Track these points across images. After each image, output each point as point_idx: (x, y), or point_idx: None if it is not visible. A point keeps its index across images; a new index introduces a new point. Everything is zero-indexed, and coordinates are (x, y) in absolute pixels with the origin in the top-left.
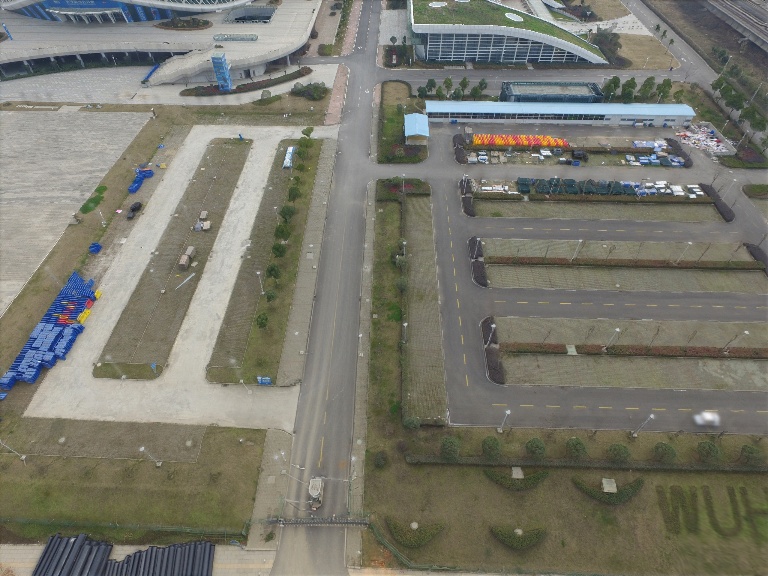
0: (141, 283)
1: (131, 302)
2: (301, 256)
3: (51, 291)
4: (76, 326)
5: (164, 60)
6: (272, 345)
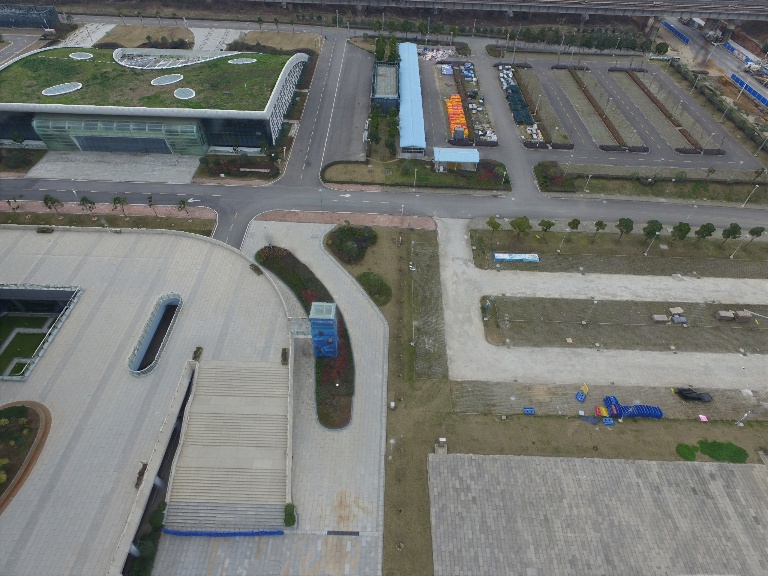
0: None
1: None
2: None
3: None
4: None
5: (162, 506)
6: None
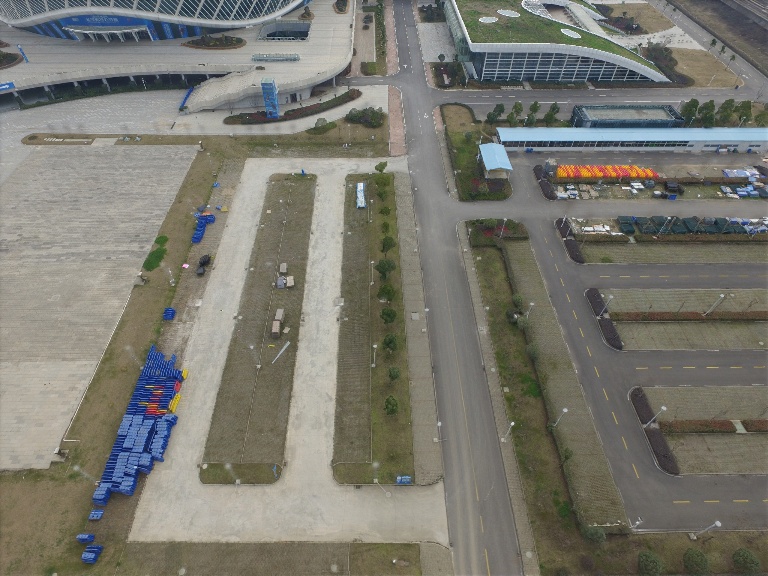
0: (231, 356)
1: (225, 382)
2: (406, 317)
3: (130, 371)
4: (170, 417)
5: (199, 83)
6: (400, 432)
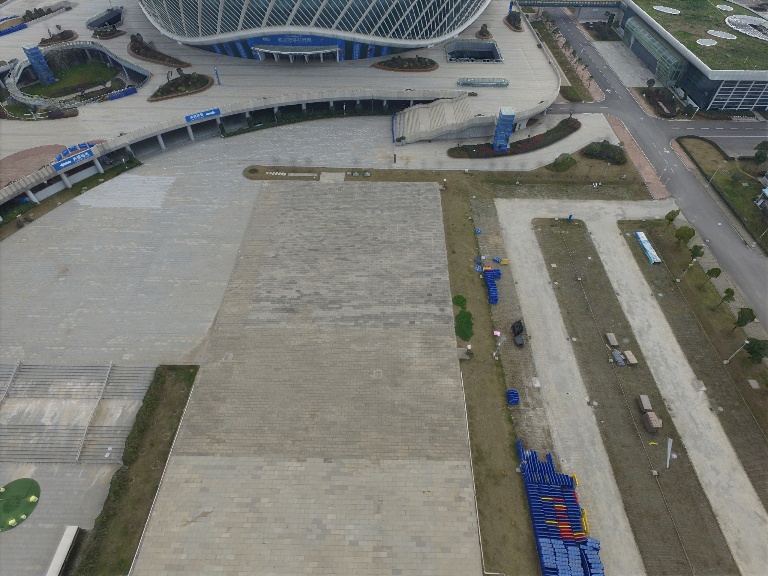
0: (613, 457)
1: (624, 492)
2: None
3: (510, 476)
4: (596, 545)
5: (402, 109)
6: None
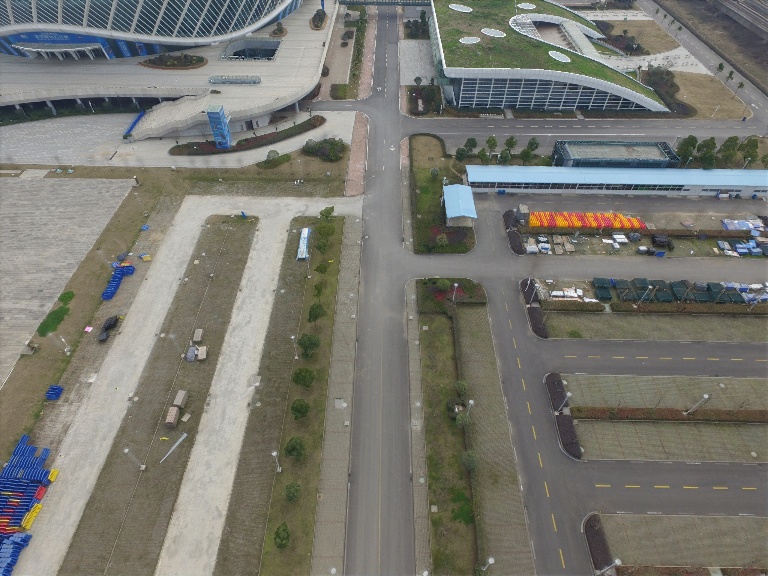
0: (114, 452)
1: (99, 487)
2: (328, 405)
3: None
4: (19, 539)
5: (151, 106)
6: (295, 566)
